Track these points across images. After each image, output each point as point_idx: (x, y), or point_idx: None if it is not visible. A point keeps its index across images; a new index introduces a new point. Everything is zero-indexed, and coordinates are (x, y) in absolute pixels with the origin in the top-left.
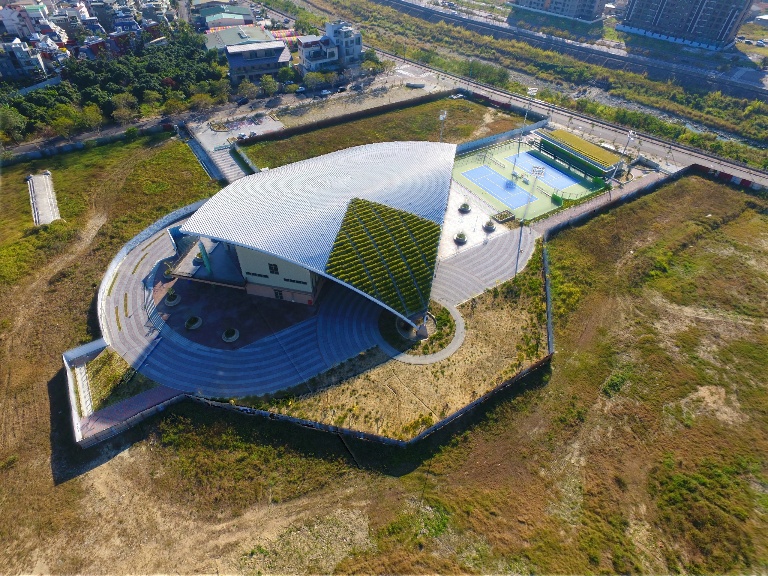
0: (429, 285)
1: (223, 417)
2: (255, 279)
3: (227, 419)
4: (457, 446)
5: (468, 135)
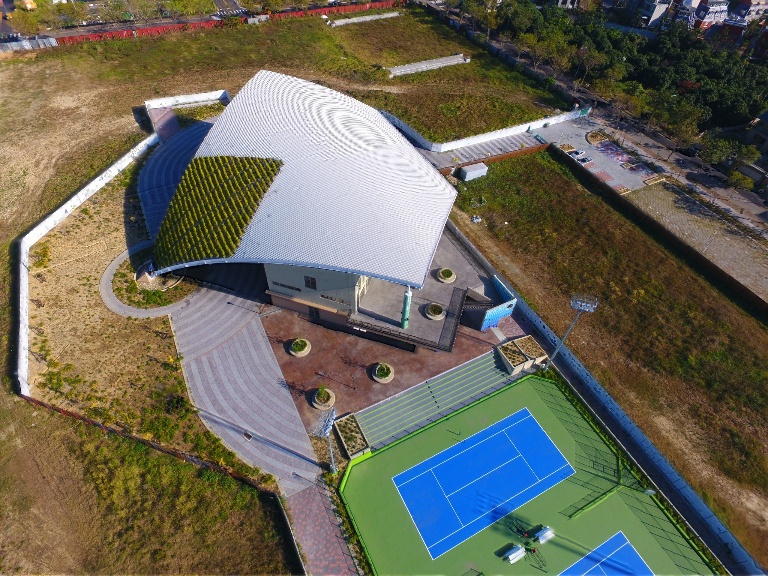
0: None
1: None
2: None
3: (124, 154)
4: (3, 281)
5: (727, 473)
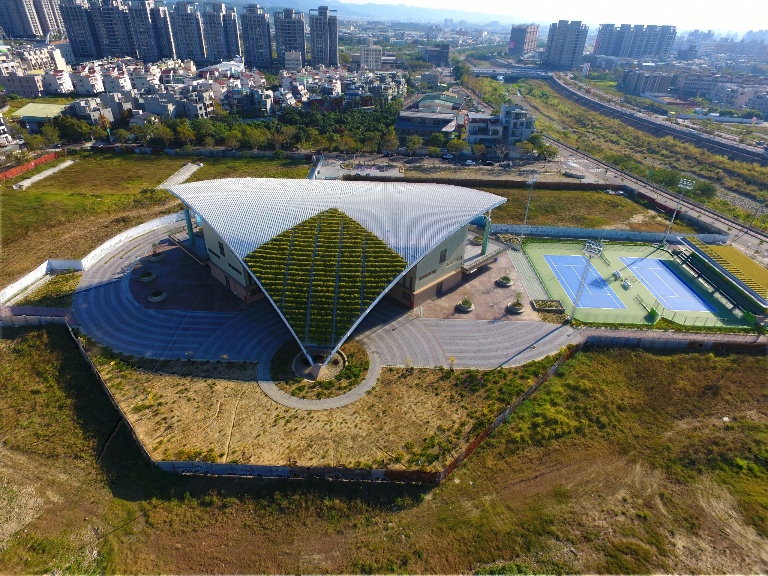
0: (351, 321)
1: (69, 351)
2: (214, 258)
3: (65, 353)
4: (206, 507)
5: (593, 226)
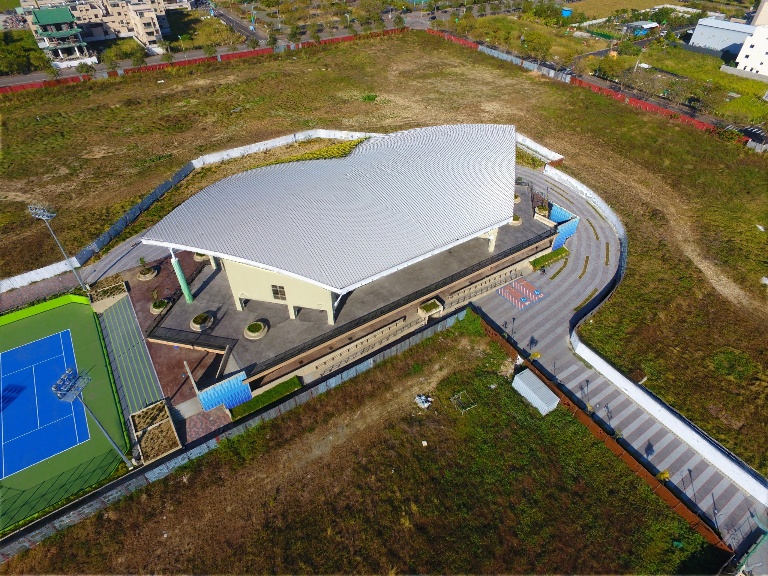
0: None
1: None
2: None
3: None
4: None
5: None
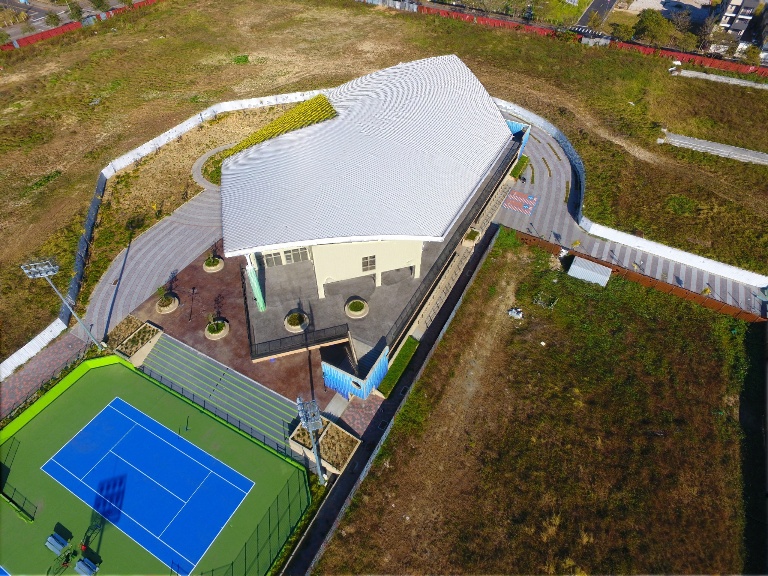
0: None
1: None
2: None
3: None
4: None
5: None
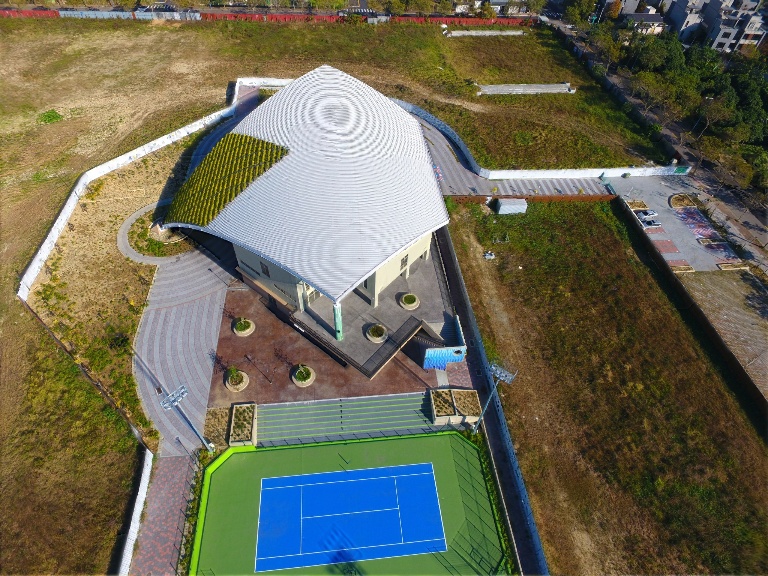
0: None
1: None
2: None
3: (198, 119)
4: None
5: None
